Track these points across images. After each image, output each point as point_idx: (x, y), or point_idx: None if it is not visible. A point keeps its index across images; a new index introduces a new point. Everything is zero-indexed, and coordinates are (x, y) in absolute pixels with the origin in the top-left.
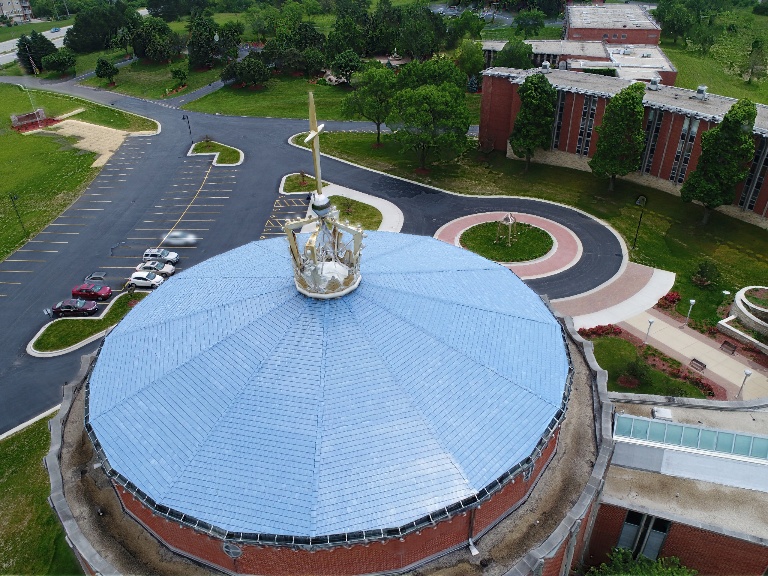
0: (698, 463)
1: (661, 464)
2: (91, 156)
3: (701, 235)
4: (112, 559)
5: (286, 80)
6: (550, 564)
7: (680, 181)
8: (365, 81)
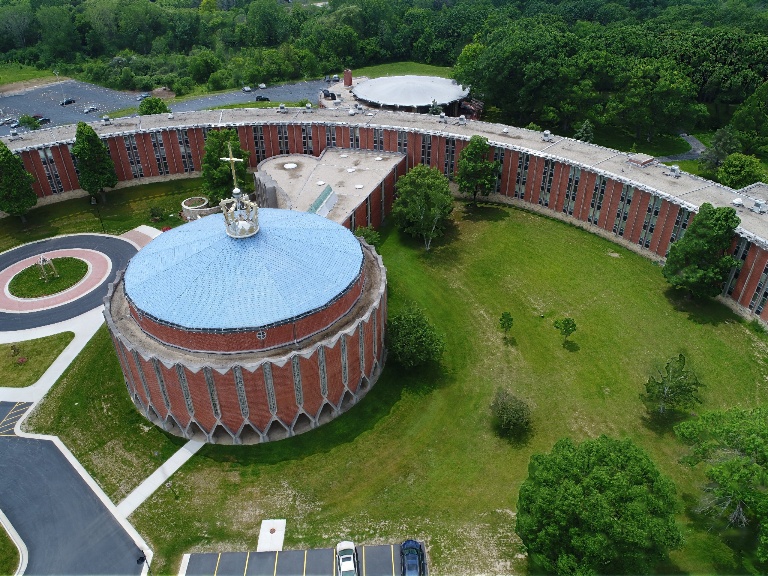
0: None
1: None
2: None
3: (114, 207)
4: None
5: None
6: None
7: (61, 190)
8: None
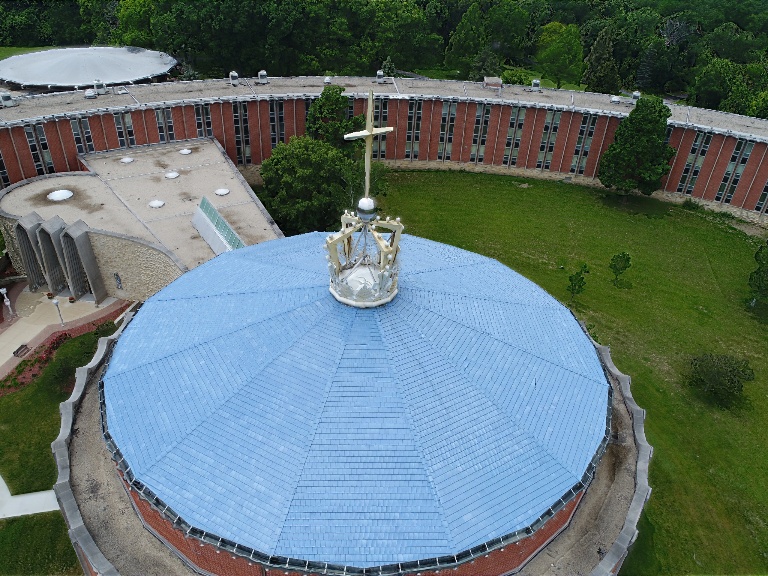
0: None
1: None
2: None
3: None
4: None
5: None
6: None
7: None
8: None
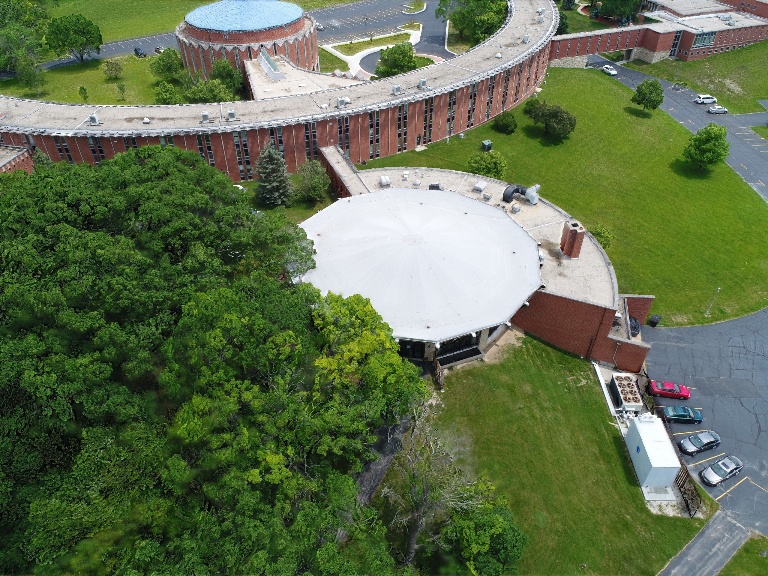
0: None
1: None
2: None
3: None
4: (182, 28)
5: None
6: (217, 53)
7: None
8: None
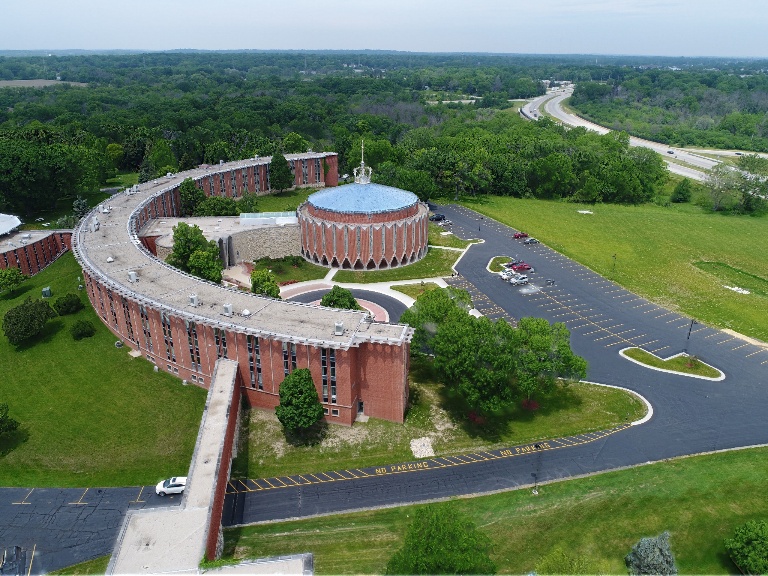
0: None
1: None
2: (765, 340)
3: None
4: None
5: None
6: None
7: None
8: None
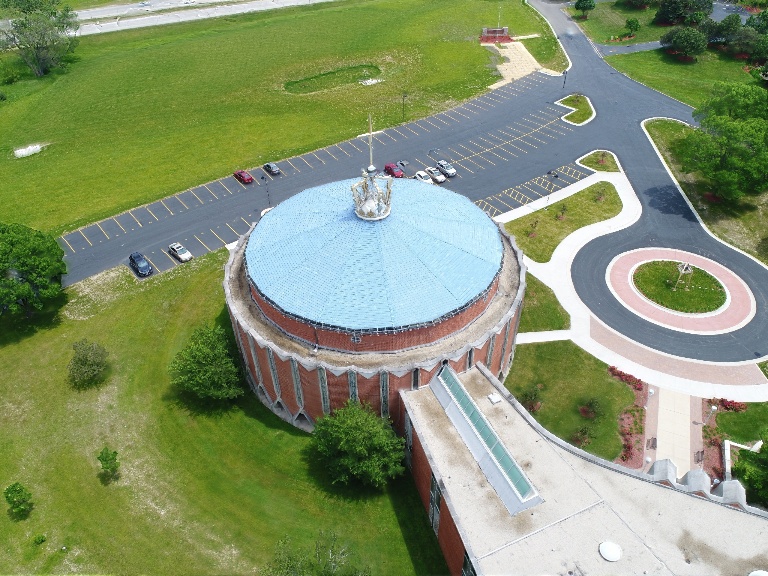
0: (460, 418)
1: (447, 406)
2: (497, 78)
3: None
4: (235, 266)
5: (724, 59)
6: (336, 380)
7: None
8: (724, 92)
